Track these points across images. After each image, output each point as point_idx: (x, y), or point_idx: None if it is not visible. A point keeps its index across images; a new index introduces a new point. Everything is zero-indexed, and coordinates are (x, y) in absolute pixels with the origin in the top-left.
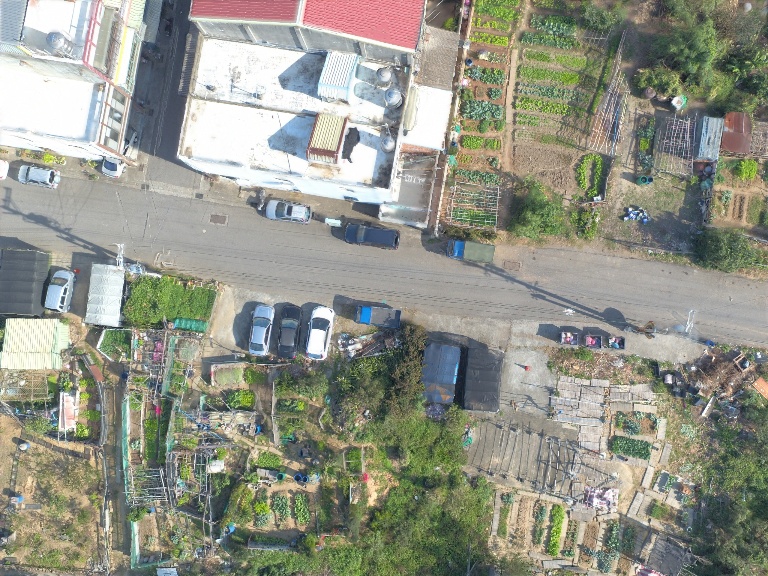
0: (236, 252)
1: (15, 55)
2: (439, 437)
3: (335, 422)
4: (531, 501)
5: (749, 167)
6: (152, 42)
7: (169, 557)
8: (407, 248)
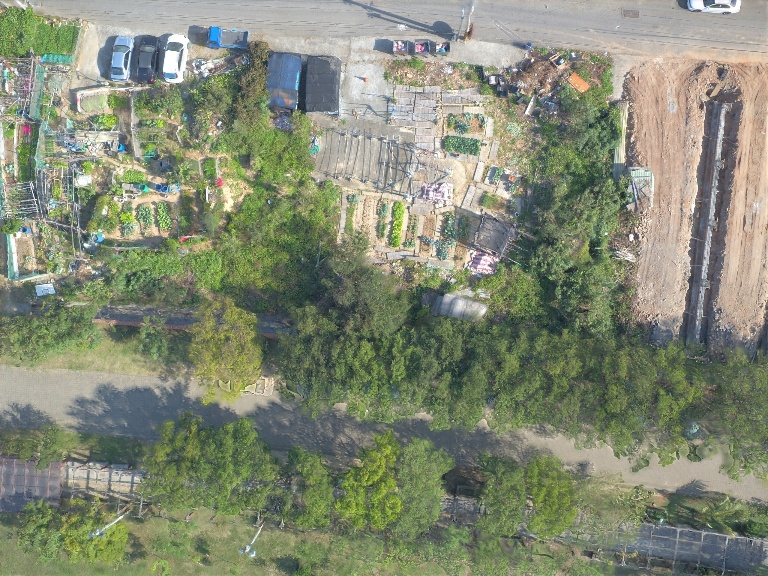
0: None
1: None
2: (288, 145)
3: (192, 136)
4: (374, 200)
5: None
6: None
7: (46, 273)
8: None
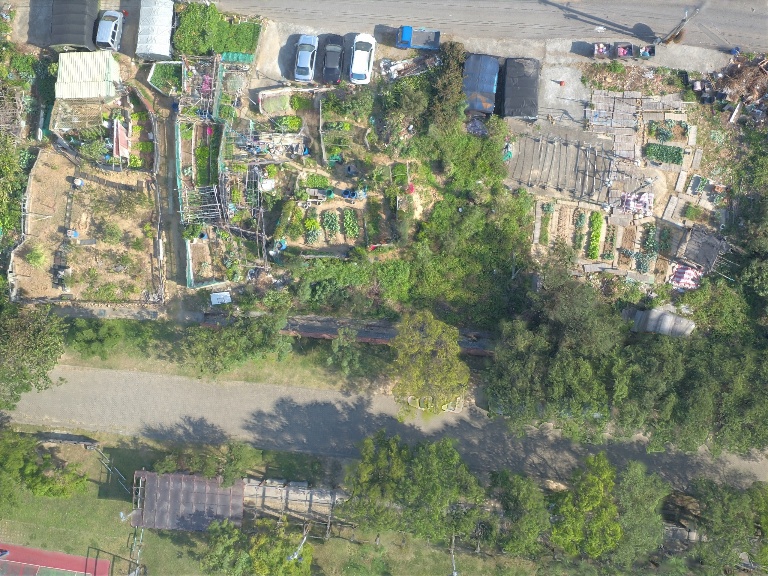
0: None
1: None
2: (480, 151)
3: (380, 140)
4: (570, 210)
5: None
6: None
7: (222, 281)
8: None
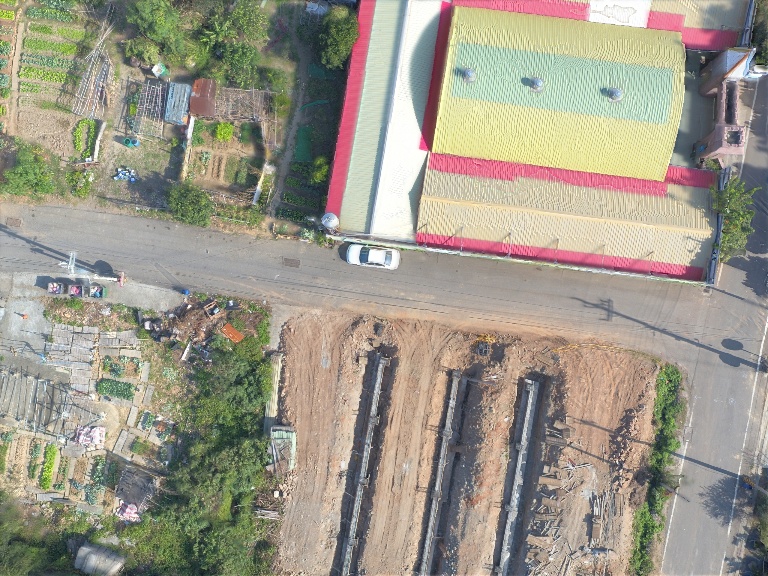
0: None
1: None
2: None
3: None
4: (28, 439)
5: (223, 130)
6: None
7: None
8: None
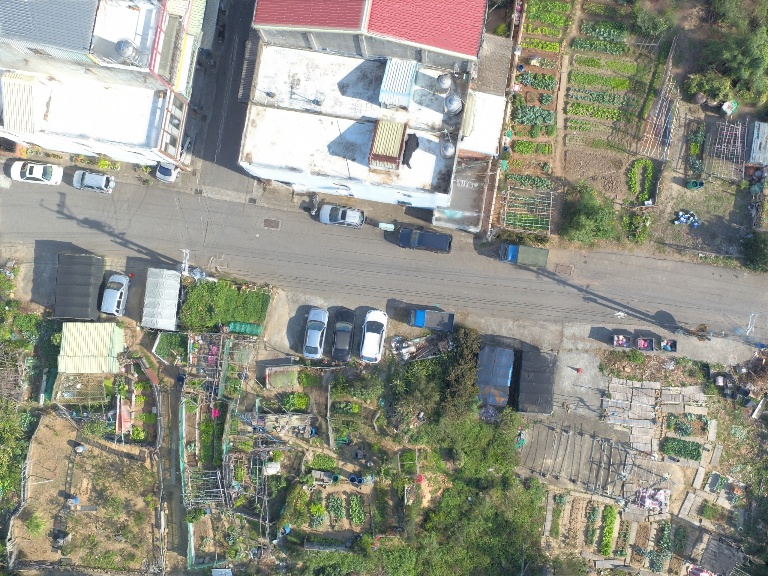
0: (289, 256)
1: (82, 63)
2: (492, 439)
3: (389, 424)
4: (583, 502)
5: None
6: (208, 49)
7: (224, 558)
8: (459, 252)
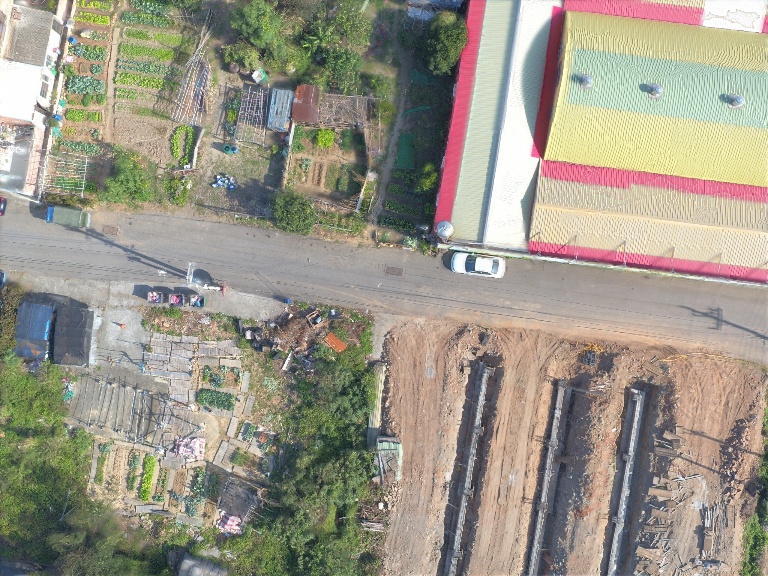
0: None
1: None
2: (40, 391)
3: None
4: (126, 450)
5: (325, 136)
6: None
7: None
8: (16, 215)
